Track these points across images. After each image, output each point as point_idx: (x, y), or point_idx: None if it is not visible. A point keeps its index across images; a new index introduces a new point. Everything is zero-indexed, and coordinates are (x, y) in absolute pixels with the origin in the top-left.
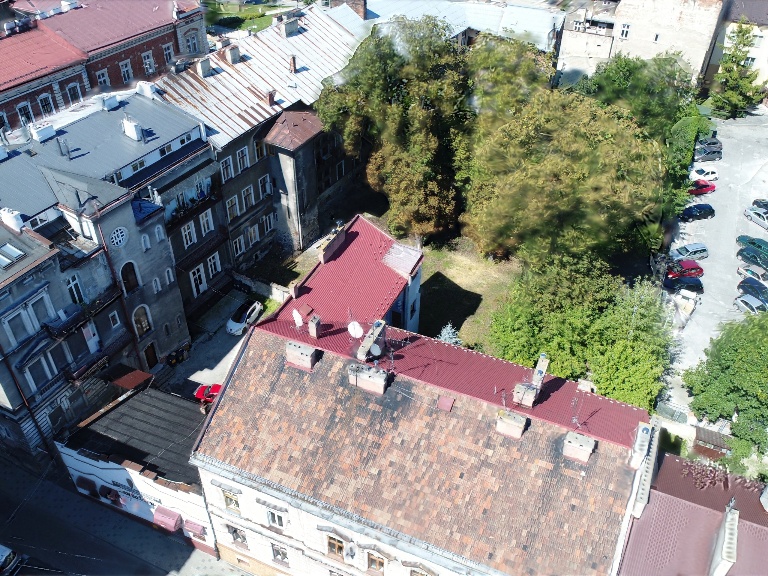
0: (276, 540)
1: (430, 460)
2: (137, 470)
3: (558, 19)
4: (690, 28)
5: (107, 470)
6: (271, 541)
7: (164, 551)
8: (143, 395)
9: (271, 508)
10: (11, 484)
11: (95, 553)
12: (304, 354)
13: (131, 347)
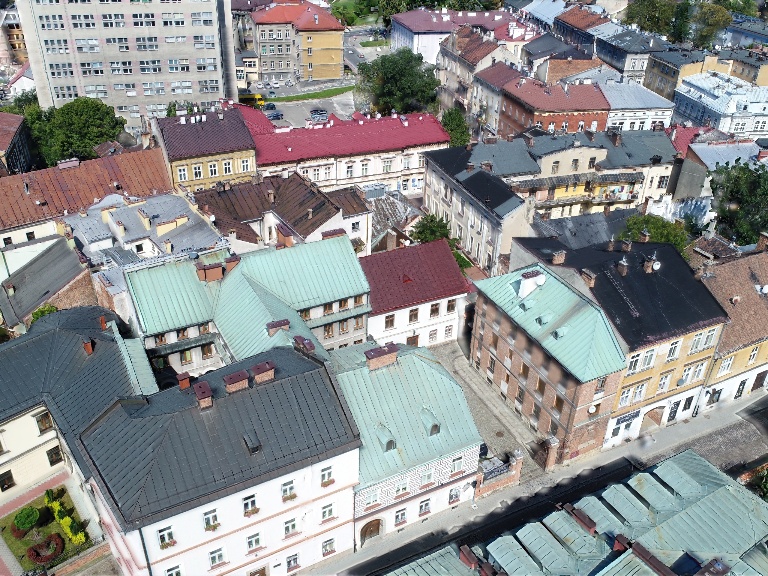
0: None
1: None
2: None
3: (599, 8)
4: (620, 8)
5: None
6: None
7: None
8: None
9: None
10: None
11: None
12: None
13: None
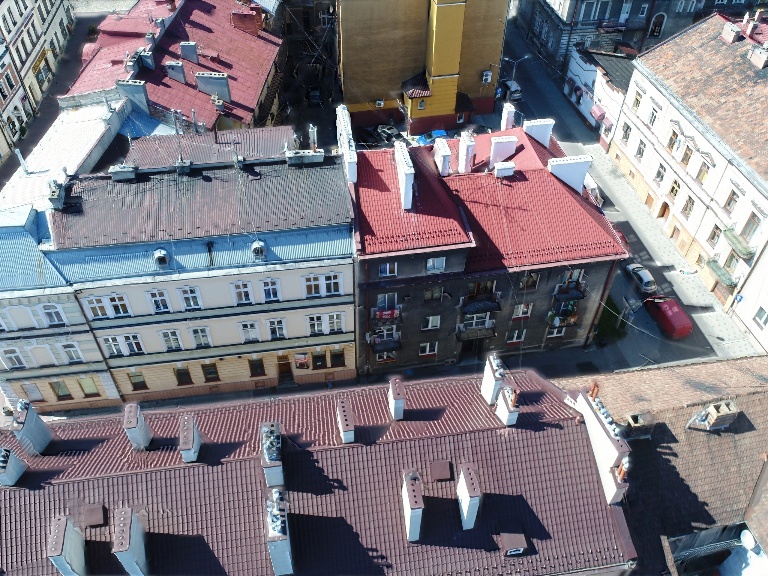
0: (645, 135)
1: (759, 107)
2: (602, 72)
3: None
4: None
5: (587, 72)
6: (642, 138)
7: (584, 135)
8: (629, 61)
9: (655, 105)
10: (536, 74)
11: (553, 117)
12: (733, 30)
13: (641, 38)
